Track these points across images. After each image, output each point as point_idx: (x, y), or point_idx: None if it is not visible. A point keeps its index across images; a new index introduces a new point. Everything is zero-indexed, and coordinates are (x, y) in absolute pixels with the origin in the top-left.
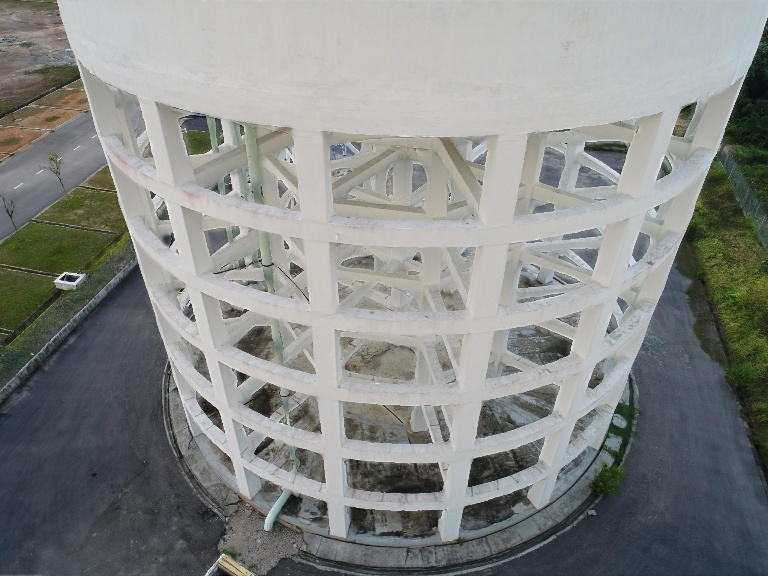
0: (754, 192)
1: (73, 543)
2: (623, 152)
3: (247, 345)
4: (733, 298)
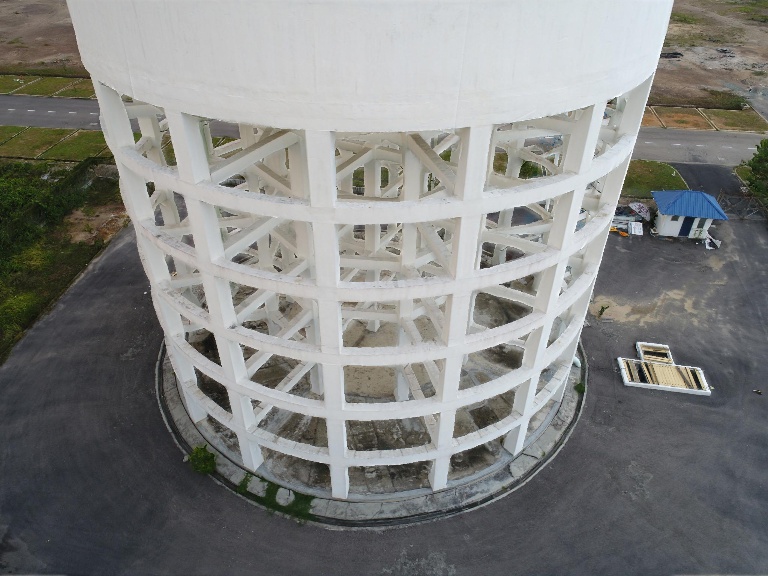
0: None
1: None
2: None
3: None
4: None
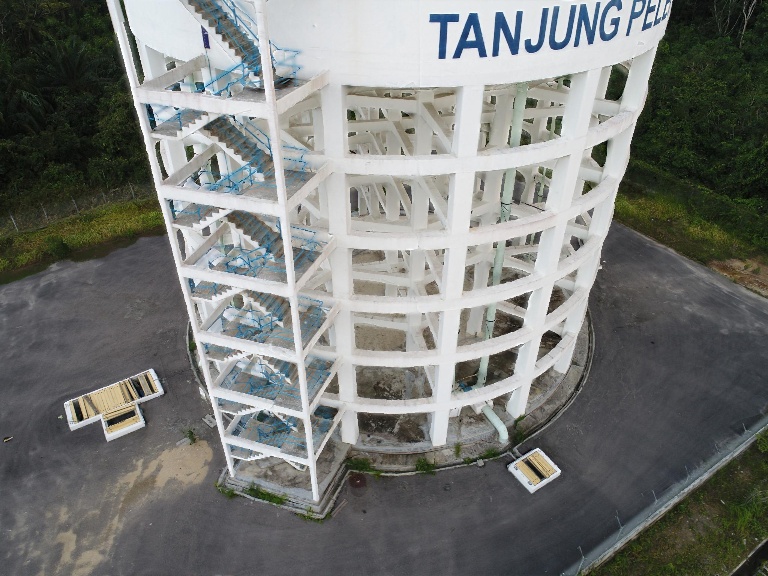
0: None
1: (667, 316)
2: None
3: (502, 362)
4: (158, 214)
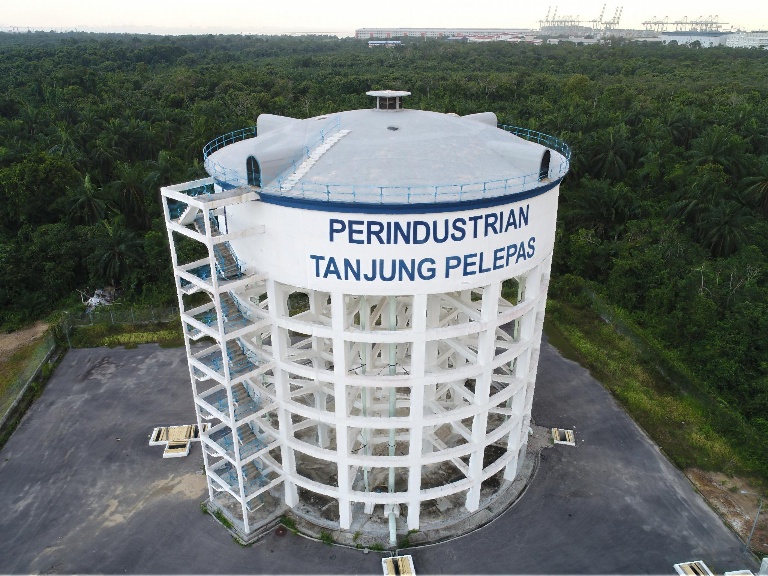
0: (161, 307)
1: (602, 499)
2: (56, 365)
3: None
4: None
